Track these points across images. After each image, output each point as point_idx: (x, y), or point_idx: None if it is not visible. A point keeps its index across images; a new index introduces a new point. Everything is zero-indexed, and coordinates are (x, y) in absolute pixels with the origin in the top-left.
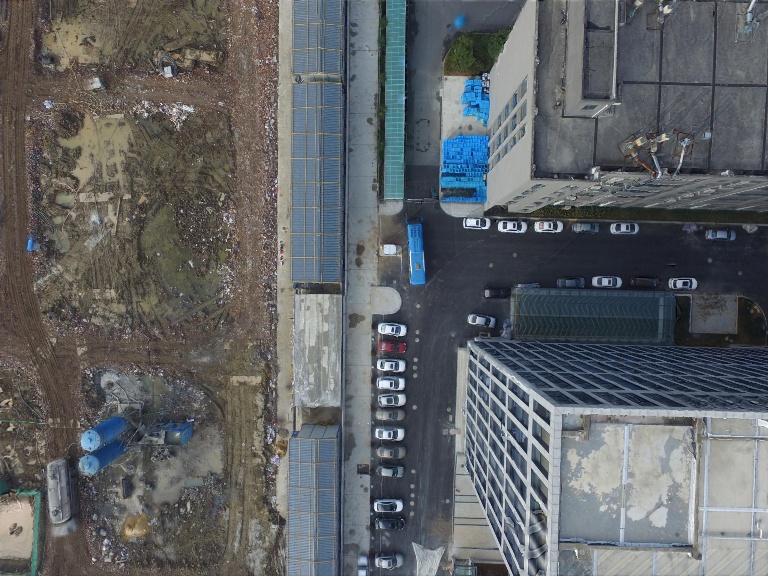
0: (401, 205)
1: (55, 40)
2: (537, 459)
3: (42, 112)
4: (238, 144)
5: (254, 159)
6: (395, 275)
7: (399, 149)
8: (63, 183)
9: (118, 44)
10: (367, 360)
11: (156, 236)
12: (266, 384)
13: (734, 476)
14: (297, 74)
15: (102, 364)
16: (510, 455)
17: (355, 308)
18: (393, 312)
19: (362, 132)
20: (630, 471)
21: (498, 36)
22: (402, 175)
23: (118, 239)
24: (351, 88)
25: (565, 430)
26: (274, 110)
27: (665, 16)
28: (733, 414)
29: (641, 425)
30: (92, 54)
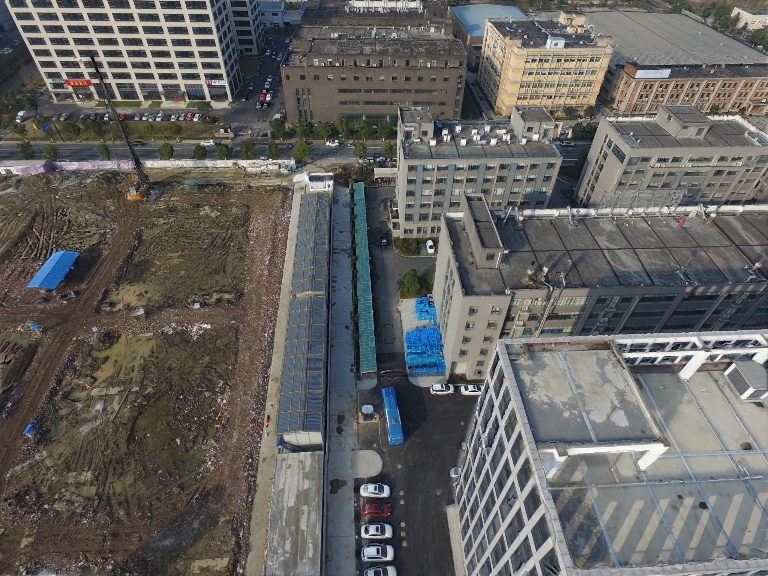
0: (375, 381)
1: (118, 295)
2: (503, 408)
3: (88, 334)
4: (241, 346)
5: (253, 356)
6: (374, 439)
7: (371, 338)
8: (82, 382)
9: (164, 294)
10: (350, 529)
11: (151, 419)
12: (233, 568)
13: (690, 424)
14: (294, 293)
15: (44, 557)
16: (494, 470)
17: (336, 473)
18: (375, 474)
19: (341, 334)
20: (576, 383)
21: (433, 271)
22: (374, 355)
23: (114, 423)
24: (333, 309)
25: (510, 355)
26: (273, 325)
27: (523, 225)
28: (635, 335)
29: (571, 351)
30: (142, 300)
